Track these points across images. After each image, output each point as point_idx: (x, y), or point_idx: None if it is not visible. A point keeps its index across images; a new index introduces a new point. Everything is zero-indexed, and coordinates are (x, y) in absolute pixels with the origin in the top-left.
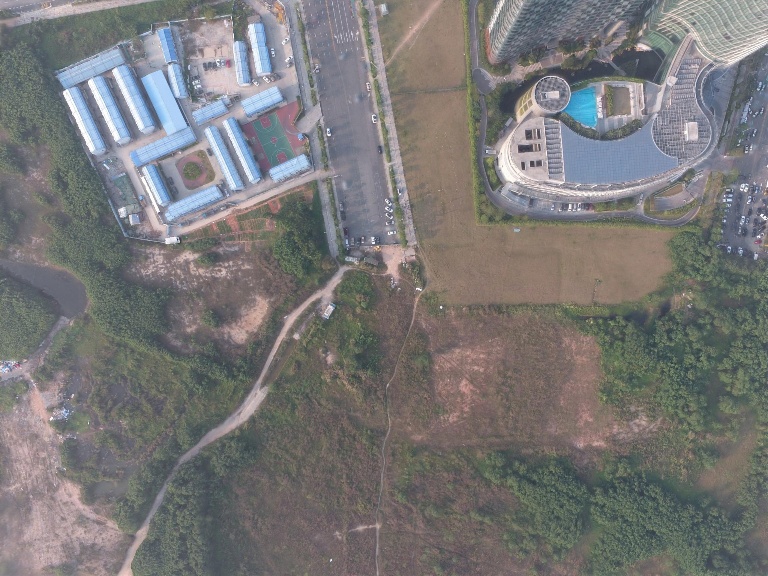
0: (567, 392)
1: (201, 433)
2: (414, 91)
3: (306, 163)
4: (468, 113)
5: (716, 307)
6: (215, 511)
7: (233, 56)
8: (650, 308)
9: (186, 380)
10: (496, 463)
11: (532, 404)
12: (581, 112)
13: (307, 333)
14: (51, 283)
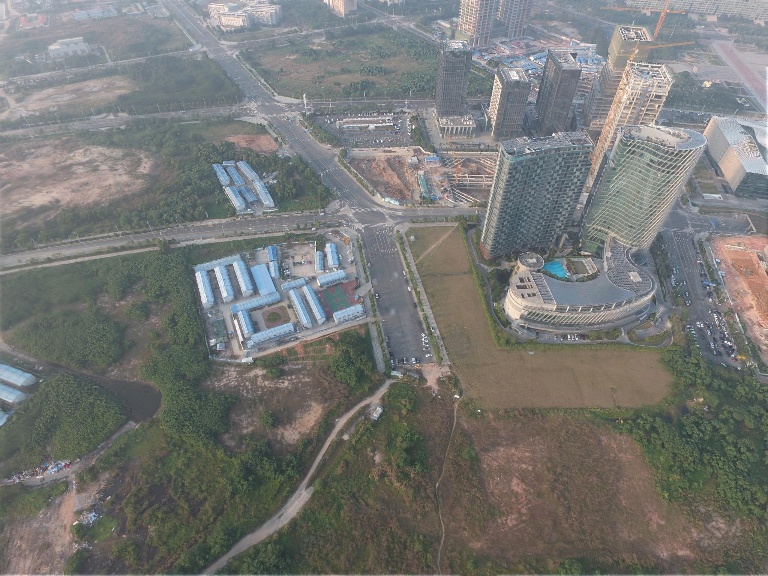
0: (625, 491)
1: (236, 535)
2: (436, 274)
3: (361, 309)
4: (476, 284)
5: None
6: None
7: (314, 259)
8: (670, 411)
9: (234, 472)
10: (573, 572)
11: (592, 503)
12: (555, 273)
13: (356, 433)
14: (131, 396)
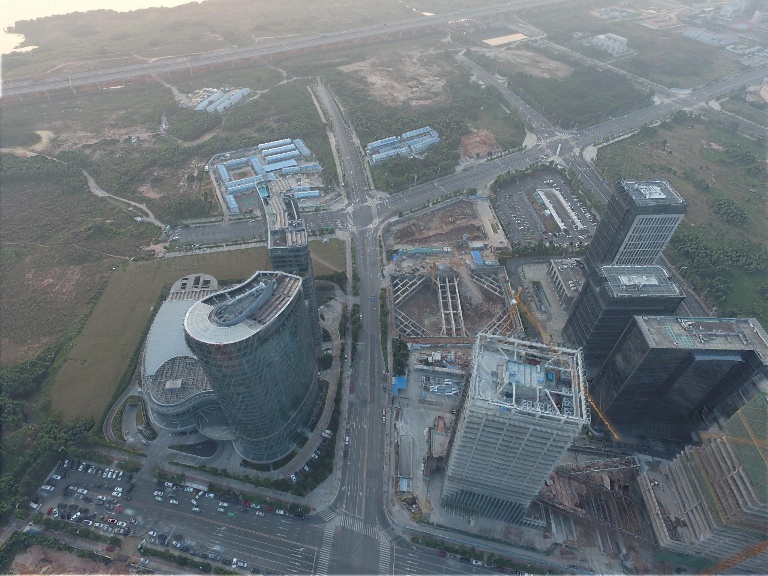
0: (0, 342)
1: None
2: None
3: (232, 207)
4: None
5: (2, 457)
6: (46, 181)
7: None
8: (37, 403)
9: None
10: None
11: (6, 318)
12: None
13: None
14: None
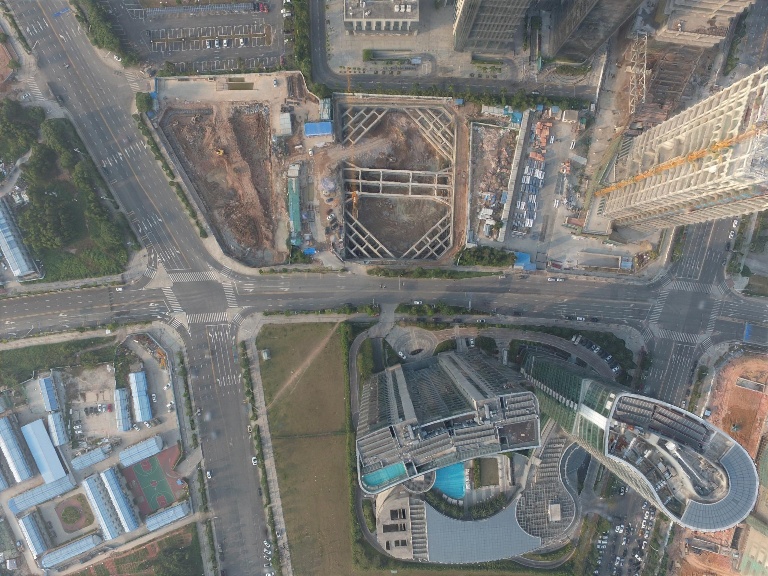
0: None
1: None
2: (294, 435)
3: (182, 515)
4: (347, 459)
5: None
6: None
7: None
8: None
9: None
10: None
11: None
12: (450, 482)
13: None
14: None
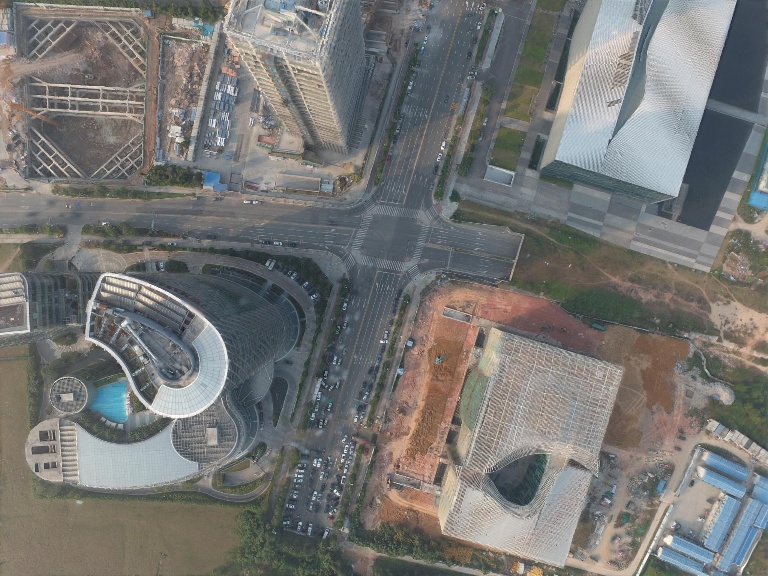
0: None
1: None
2: None
3: None
4: None
5: None
6: None
7: None
8: None
9: None
10: None
11: None
12: (113, 405)
13: None
14: None
